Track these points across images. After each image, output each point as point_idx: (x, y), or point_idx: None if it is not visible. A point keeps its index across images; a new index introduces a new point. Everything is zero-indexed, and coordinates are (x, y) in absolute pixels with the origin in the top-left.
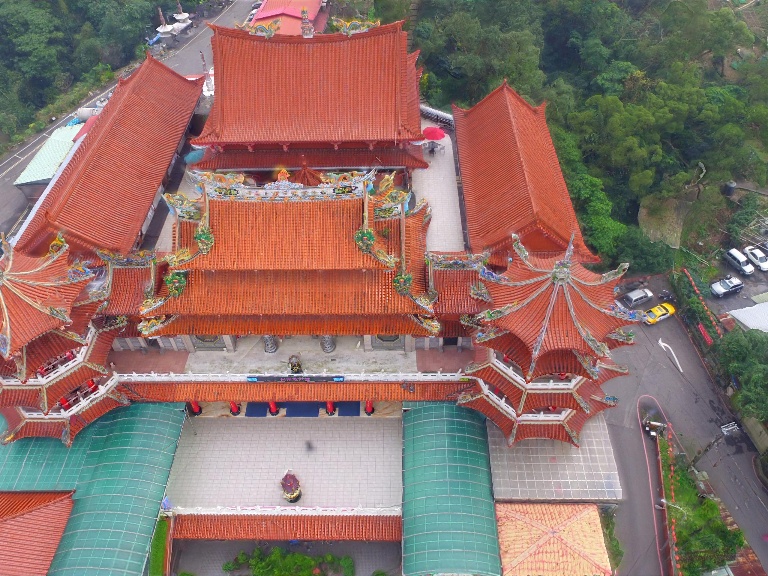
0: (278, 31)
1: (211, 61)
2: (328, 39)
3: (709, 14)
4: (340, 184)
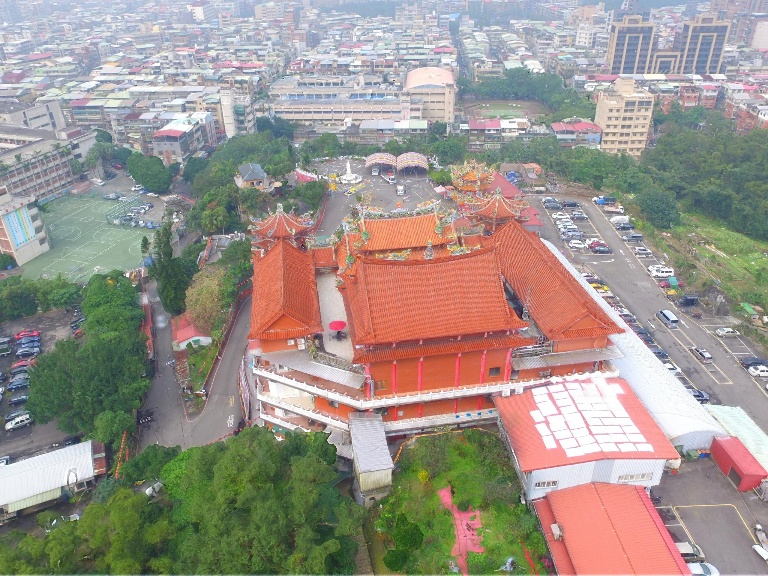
0: (451, 254)
1: None
2: (415, 262)
3: None
4: (374, 212)
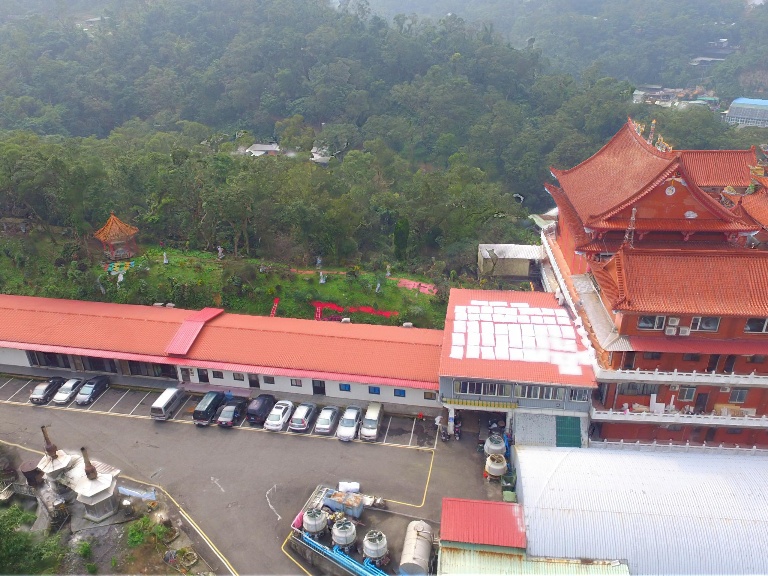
0: None
1: (223, 437)
2: None
3: (350, 158)
4: None
